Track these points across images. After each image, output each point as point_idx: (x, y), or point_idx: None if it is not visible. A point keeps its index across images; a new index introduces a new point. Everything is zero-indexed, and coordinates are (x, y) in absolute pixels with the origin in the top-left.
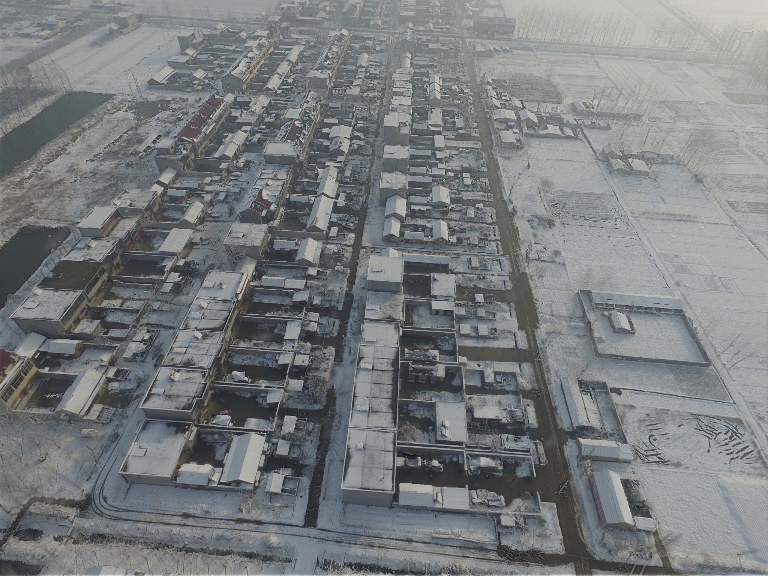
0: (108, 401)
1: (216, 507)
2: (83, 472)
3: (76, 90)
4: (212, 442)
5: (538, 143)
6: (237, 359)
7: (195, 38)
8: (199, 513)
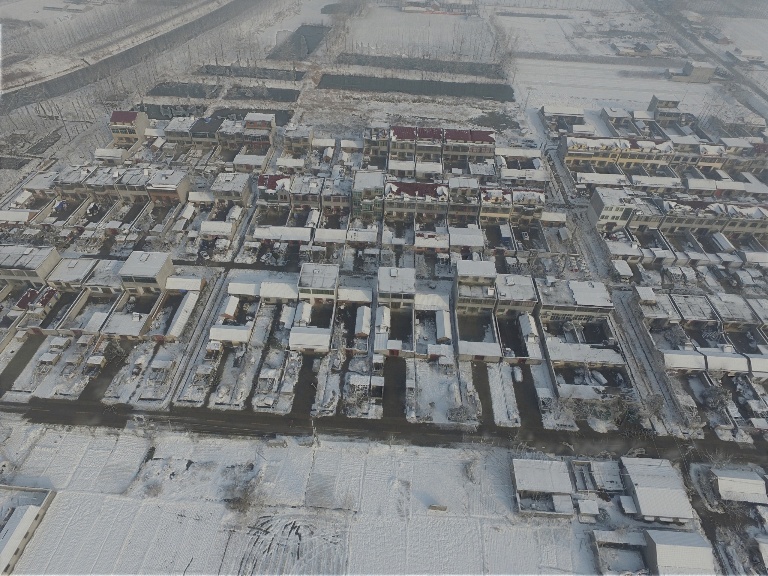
0: None
1: None
2: None
3: (512, 86)
4: None
5: (566, 566)
6: None
7: (674, 107)
8: (3, 207)
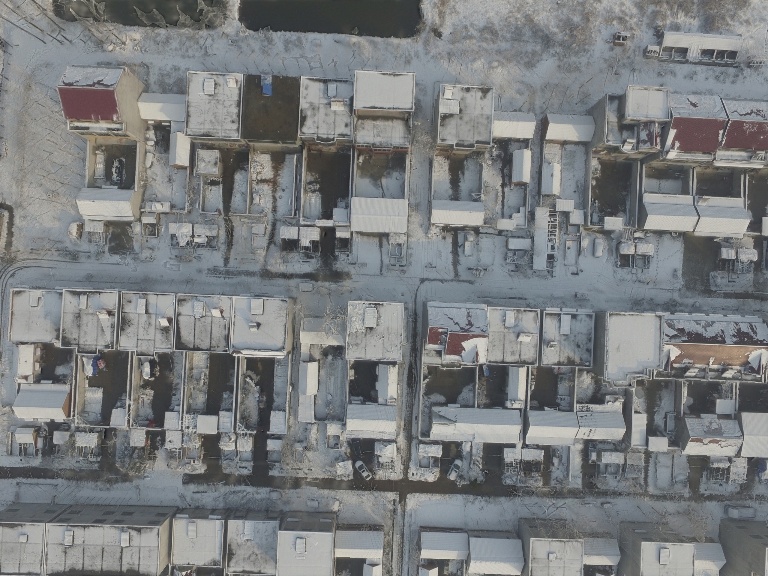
0: (117, 230)
1: (8, 382)
2: (37, 242)
3: None
4: (71, 359)
5: None
6: (180, 357)
7: None
8: (2, 368)
